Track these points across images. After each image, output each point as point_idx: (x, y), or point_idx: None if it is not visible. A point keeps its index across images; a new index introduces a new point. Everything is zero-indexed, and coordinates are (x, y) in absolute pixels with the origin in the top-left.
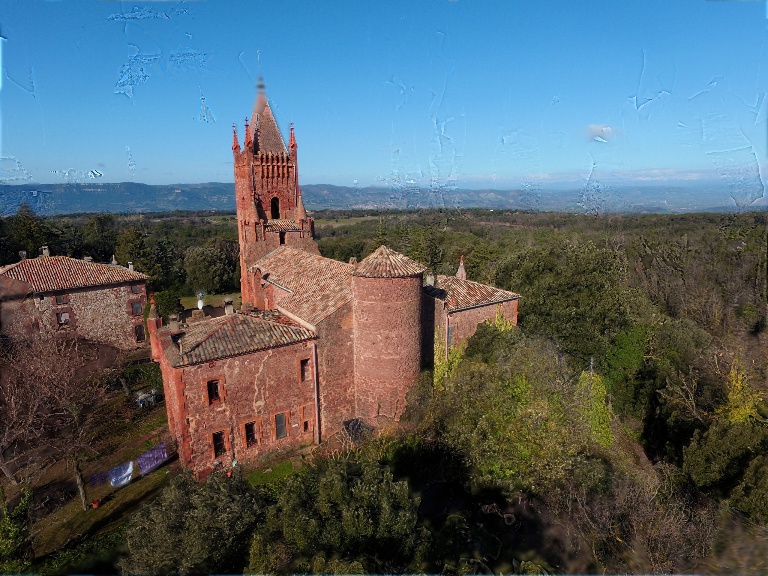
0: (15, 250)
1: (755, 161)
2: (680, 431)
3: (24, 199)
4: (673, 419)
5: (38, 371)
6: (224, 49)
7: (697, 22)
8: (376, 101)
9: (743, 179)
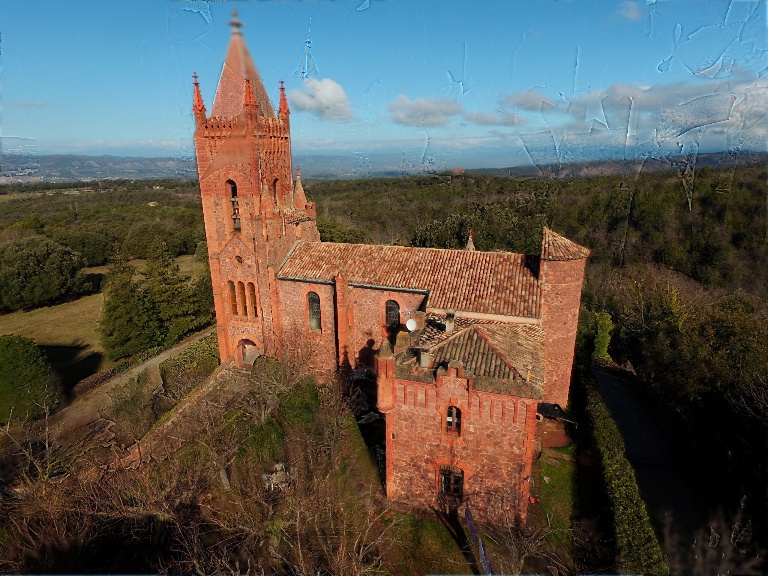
0: None
1: (553, 142)
2: (632, 340)
3: None
4: (624, 333)
5: None
6: None
7: (529, 29)
8: (199, 52)
9: (544, 155)
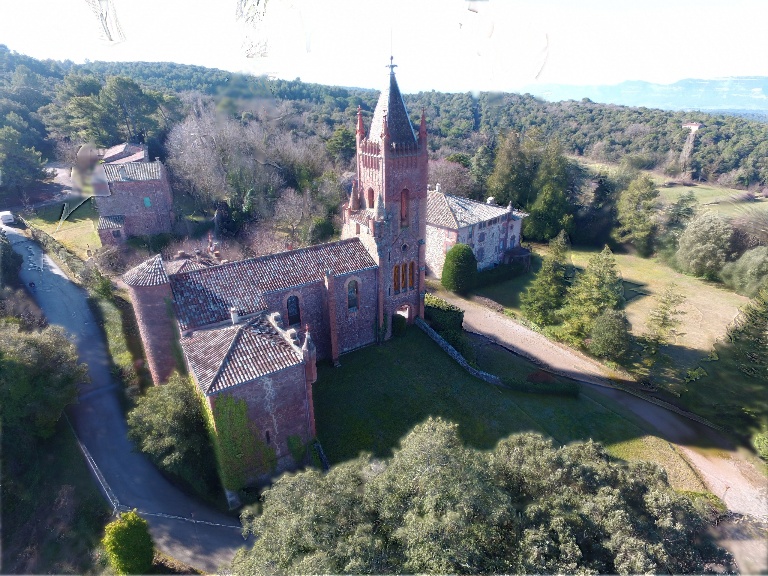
0: (534, 177)
1: None
2: None
3: (514, 139)
4: None
5: None
6: None
7: None
8: None
9: None
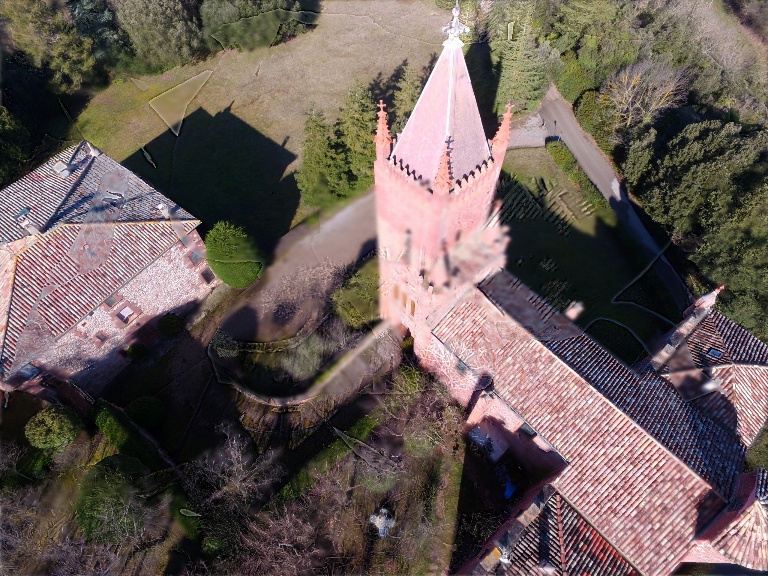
0: None
1: None
2: None
3: None
4: None
5: (287, 572)
6: (606, 310)
7: None
8: None
9: None
